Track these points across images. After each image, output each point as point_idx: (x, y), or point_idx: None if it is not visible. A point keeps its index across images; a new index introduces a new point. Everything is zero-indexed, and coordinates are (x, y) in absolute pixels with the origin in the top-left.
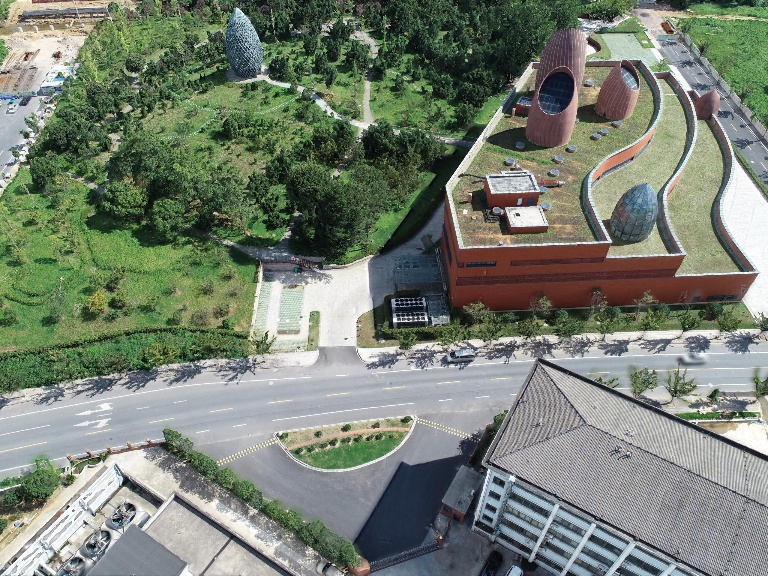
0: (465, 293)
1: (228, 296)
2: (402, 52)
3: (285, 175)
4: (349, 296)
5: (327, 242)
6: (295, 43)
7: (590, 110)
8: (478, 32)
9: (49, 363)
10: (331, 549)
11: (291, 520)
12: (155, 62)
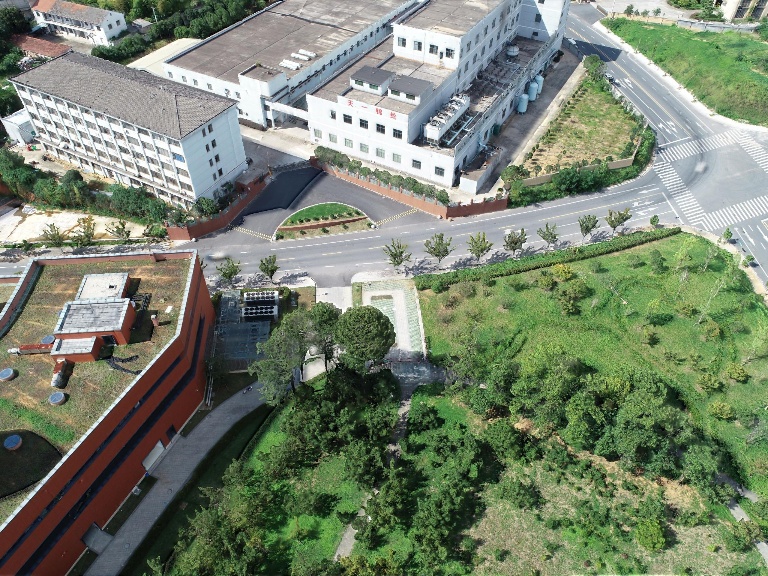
0: None
1: (451, 320)
2: None
3: None
4: None
5: None
6: None
7: None
8: None
9: None
10: None
11: (353, 160)
12: None
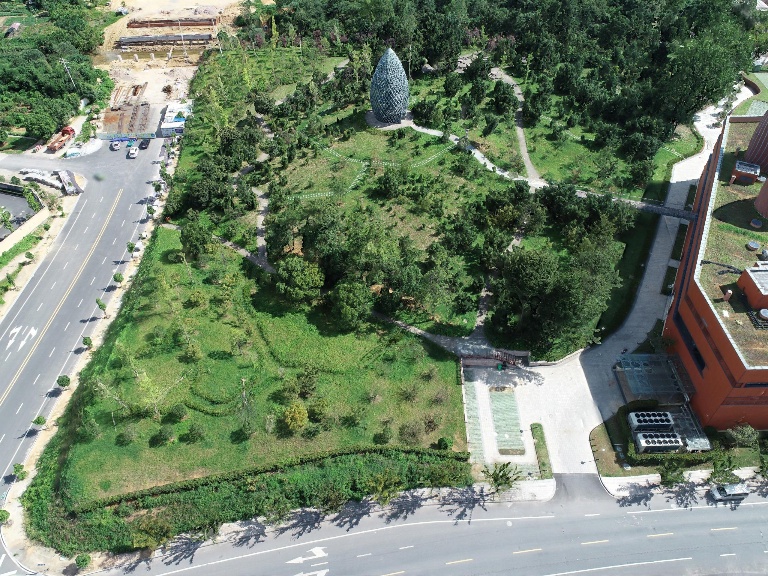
0: (727, 412)
1: (432, 402)
2: (550, 94)
3: (463, 245)
4: (570, 403)
5: (538, 336)
6: (431, 82)
7: None
8: (624, 70)
9: (247, 493)
10: None
11: None
12: (280, 101)
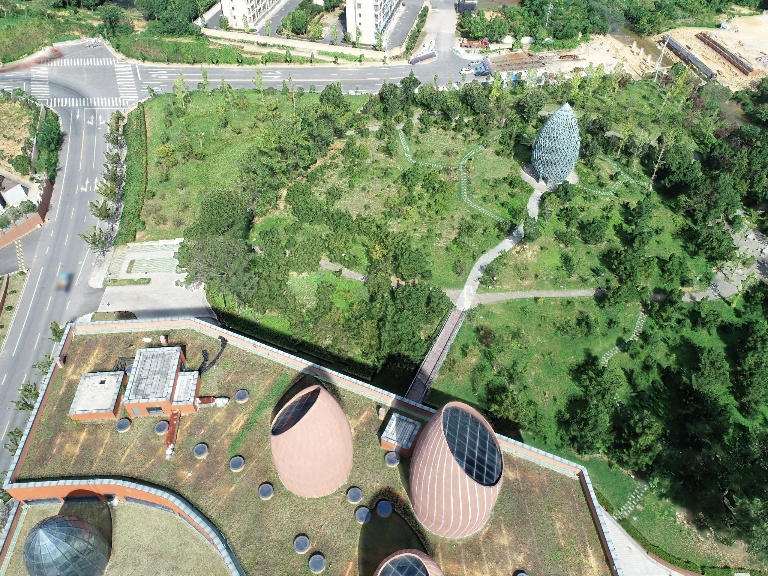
0: None
1: (178, 222)
2: (700, 325)
3: None
4: (163, 304)
5: None
6: None
7: None
8: None
9: None
10: None
11: None
12: None
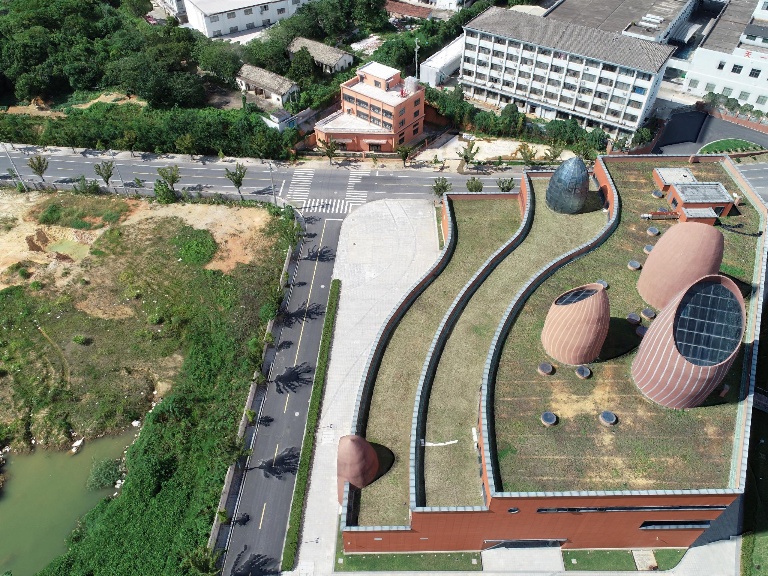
0: None
1: None
2: None
3: None
4: None
5: None
6: None
7: (608, 345)
8: None
9: None
10: (720, 94)
11: (746, 104)
12: None
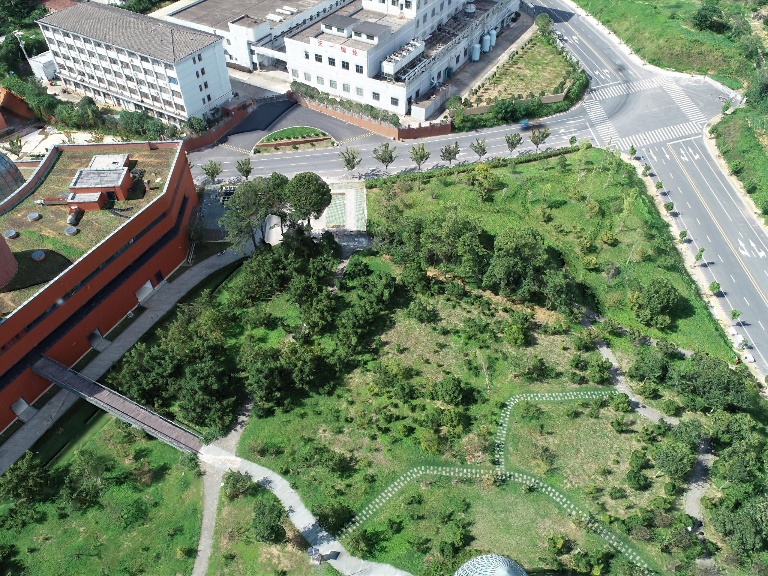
0: None
1: None
2: None
3: None
4: None
5: None
6: None
7: None
8: None
9: None
10: None
11: (322, 92)
12: None
